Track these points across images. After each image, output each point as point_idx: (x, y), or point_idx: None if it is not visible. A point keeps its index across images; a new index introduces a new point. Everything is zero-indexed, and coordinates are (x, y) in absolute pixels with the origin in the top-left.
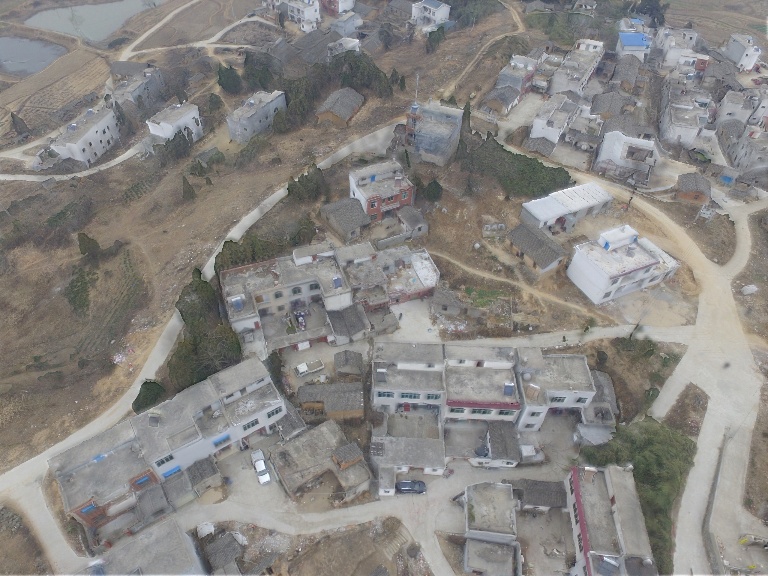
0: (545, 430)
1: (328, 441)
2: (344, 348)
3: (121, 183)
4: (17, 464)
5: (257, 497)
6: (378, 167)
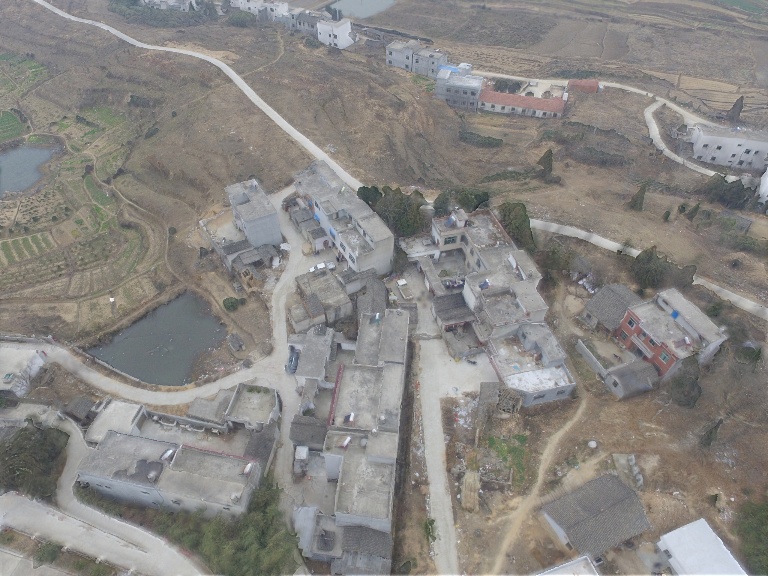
0: (328, 487)
1: (331, 298)
2: (430, 316)
3: (670, 180)
4: (340, 165)
5: (302, 270)
6: (701, 317)
